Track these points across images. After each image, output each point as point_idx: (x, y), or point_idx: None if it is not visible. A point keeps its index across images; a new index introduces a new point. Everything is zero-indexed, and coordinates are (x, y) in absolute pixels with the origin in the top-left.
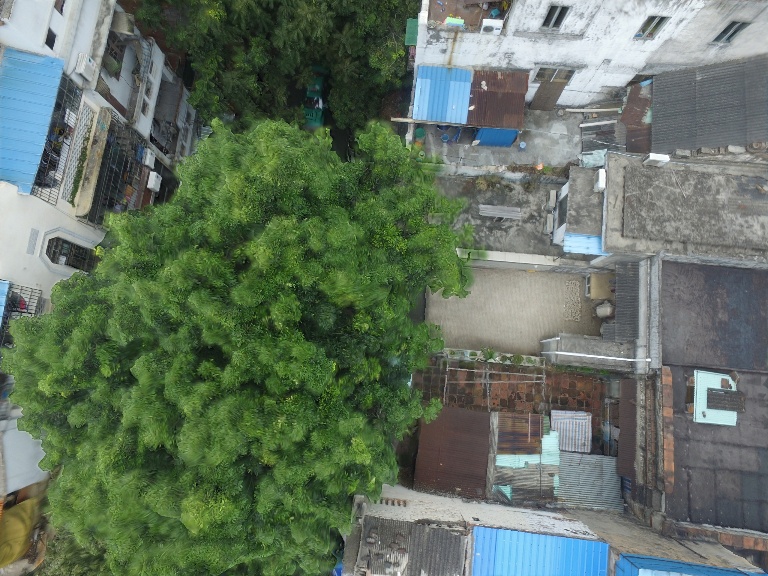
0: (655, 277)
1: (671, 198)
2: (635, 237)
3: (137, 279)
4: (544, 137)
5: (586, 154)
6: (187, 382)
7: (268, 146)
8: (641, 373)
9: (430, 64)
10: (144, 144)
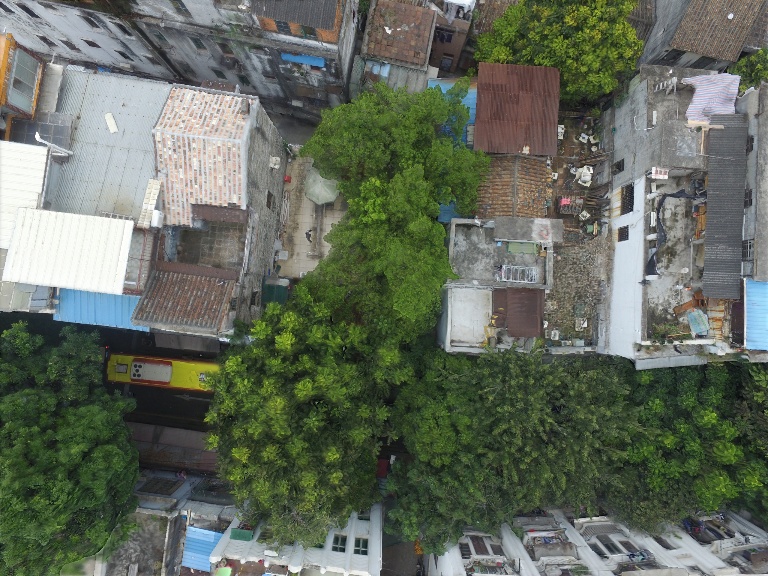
0: None
1: None
2: None
3: None
4: None
5: None
6: None
7: None
8: None
9: None
10: None
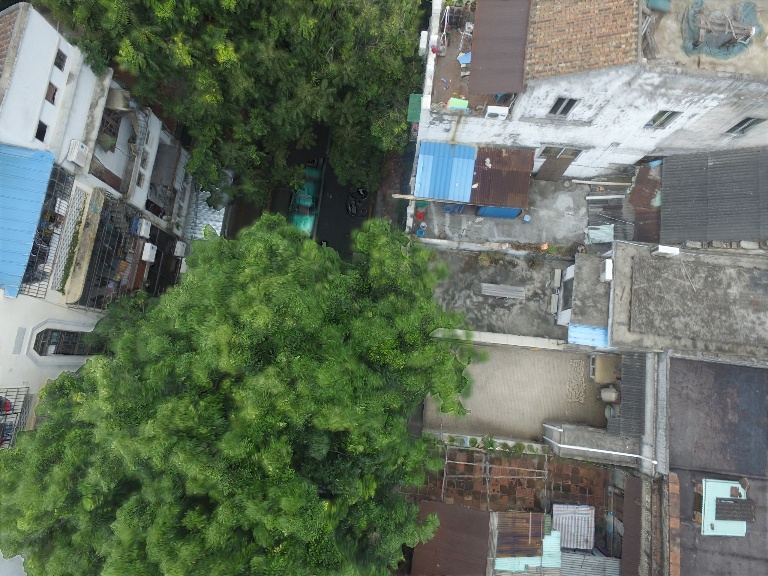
0: (663, 375)
1: (680, 291)
2: (642, 332)
3: (120, 425)
4: (549, 209)
5: (592, 228)
6: (170, 537)
7: (260, 273)
8: (647, 473)
9: (433, 140)
10: (139, 215)
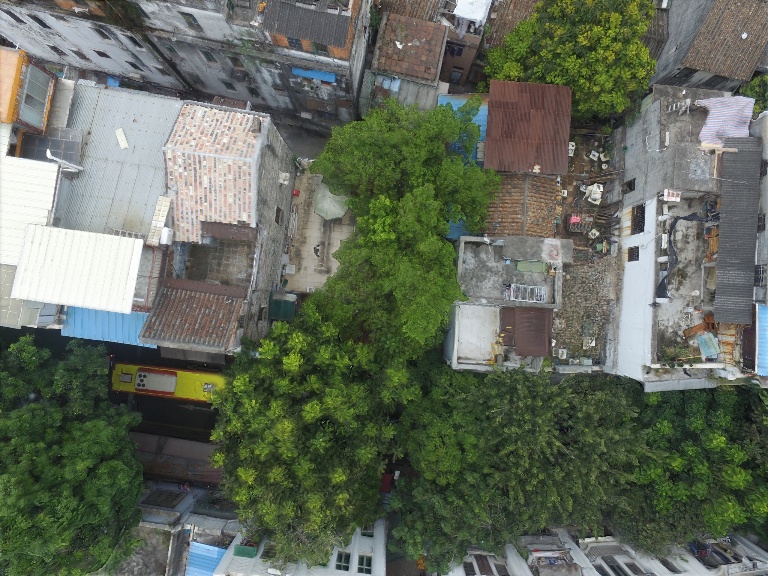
0: None
1: None
2: None
3: None
4: None
5: None
6: None
7: None
8: None
9: None
10: None
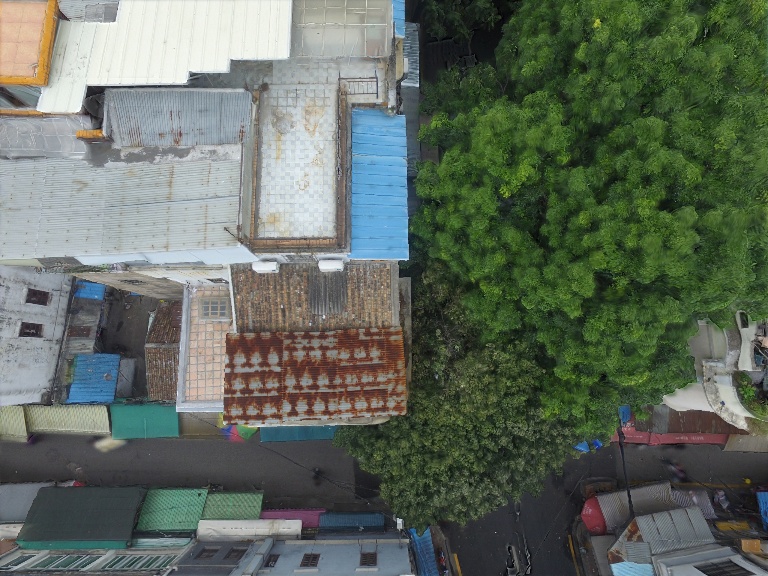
0: None
1: None
2: None
3: None
4: None
5: None
6: None
7: None
8: None
9: None
10: None
